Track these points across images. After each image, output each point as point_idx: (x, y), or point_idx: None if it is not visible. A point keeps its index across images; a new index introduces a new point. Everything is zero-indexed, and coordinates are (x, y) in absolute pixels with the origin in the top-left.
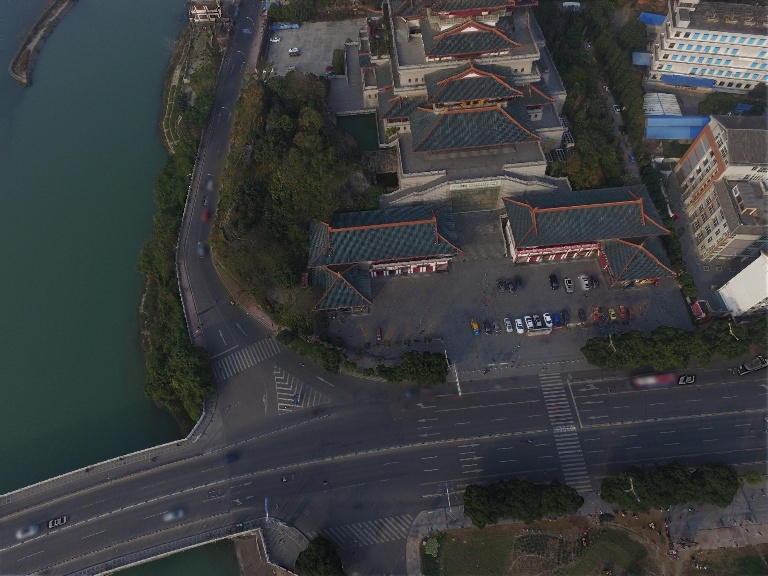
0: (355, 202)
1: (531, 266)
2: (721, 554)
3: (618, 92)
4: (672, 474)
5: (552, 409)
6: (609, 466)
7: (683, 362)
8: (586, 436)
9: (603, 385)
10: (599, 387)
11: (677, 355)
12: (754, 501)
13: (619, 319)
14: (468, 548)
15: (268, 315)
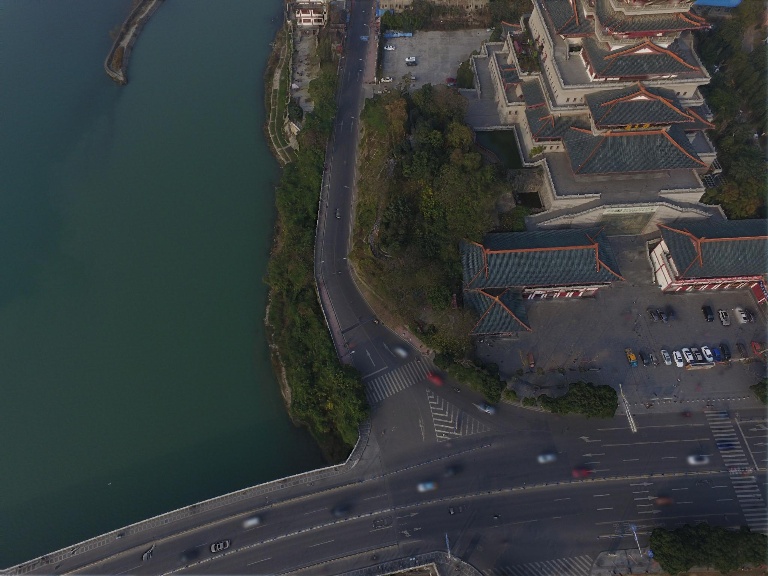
0: (501, 222)
1: (681, 295)
2: None
3: (755, 117)
4: None
5: (724, 449)
6: None
7: None
8: (764, 480)
9: None
10: None
11: None
12: None
13: None
14: None
15: (417, 336)
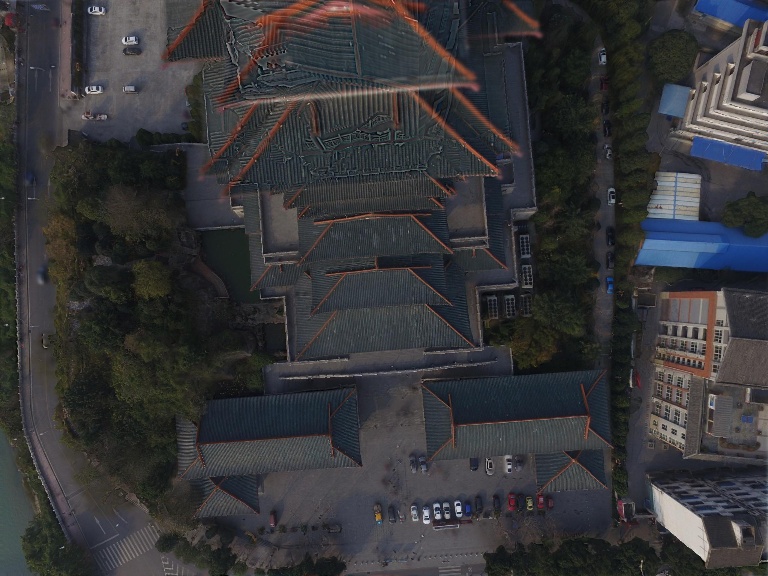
0: None
1: None
2: None
3: (621, 170)
4: None
5: None
6: None
7: None
8: None
9: None
10: None
11: None
12: None
13: (536, 509)
14: None
15: None
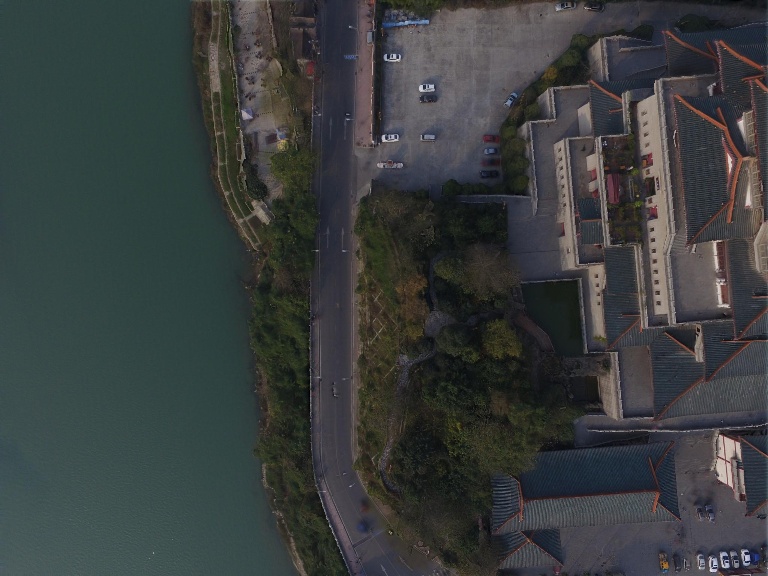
0: None
1: None
2: None
3: None
4: None
5: None
6: None
7: None
8: None
9: None
10: None
11: None
12: None
13: None
14: None
15: None
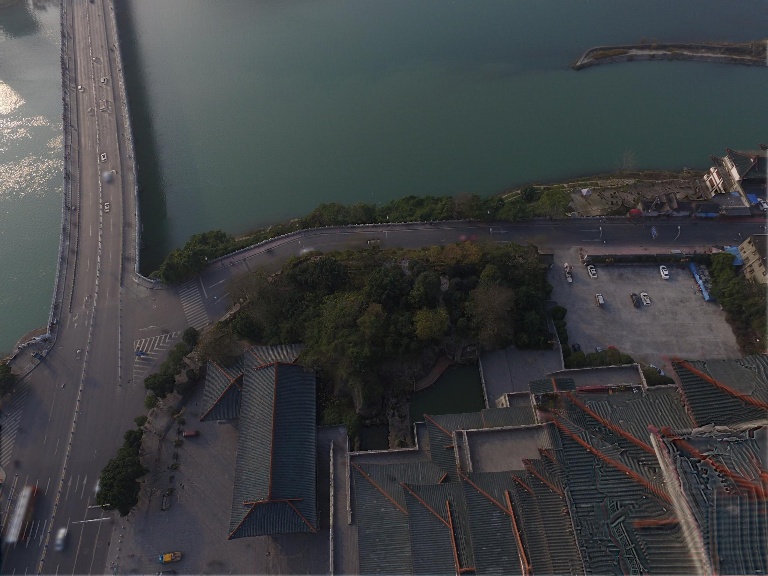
0: None
1: None
2: None
3: None
4: None
5: None
6: None
7: None
8: None
9: None
10: None
11: None
12: None
13: None
14: None
15: None
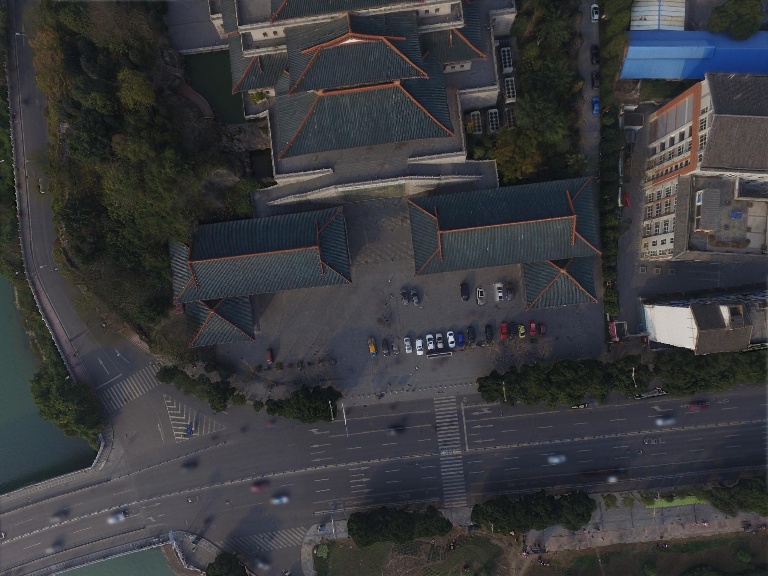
0: (223, 202)
1: None
2: (564, 554)
3: None
4: (534, 509)
5: (442, 433)
6: (486, 485)
7: (575, 402)
8: (470, 459)
9: (496, 409)
10: (492, 411)
11: (570, 398)
12: (607, 513)
13: (528, 337)
14: (353, 552)
15: (146, 343)
